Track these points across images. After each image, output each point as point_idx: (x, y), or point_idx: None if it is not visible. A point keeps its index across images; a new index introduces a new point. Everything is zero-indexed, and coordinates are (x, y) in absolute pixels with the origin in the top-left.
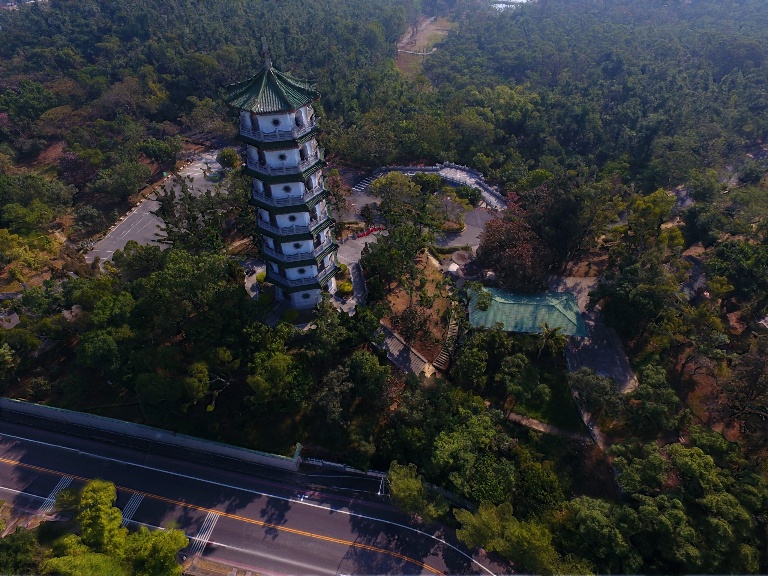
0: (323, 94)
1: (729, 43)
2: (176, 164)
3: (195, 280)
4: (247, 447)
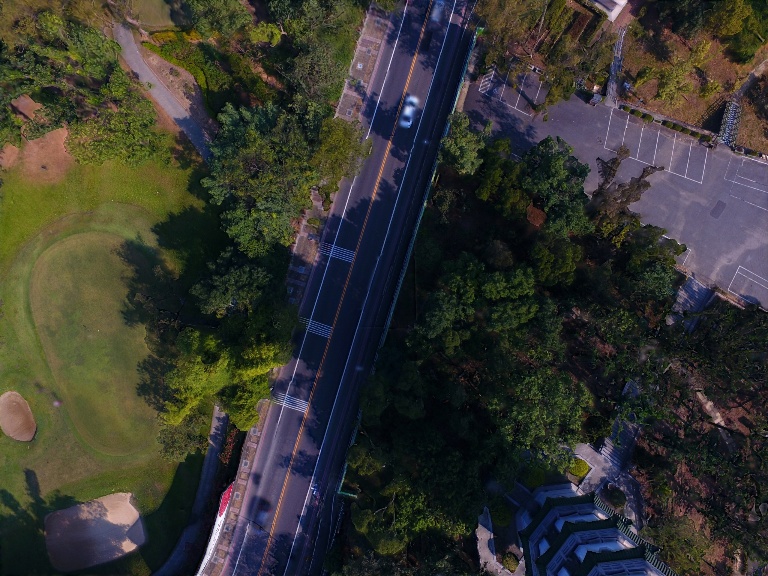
0: None
1: None
2: None
3: (510, 447)
4: (358, 442)
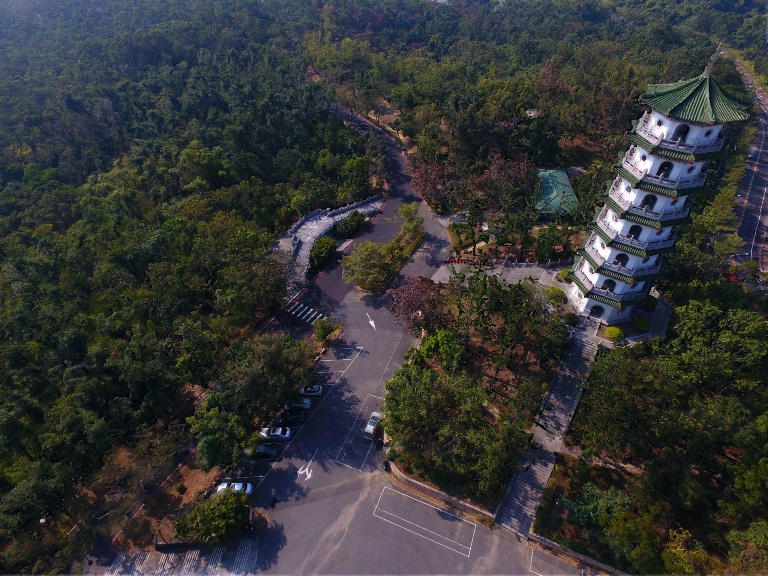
0: (17, 358)
1: (134, 41)
2: None
3: None
4: None
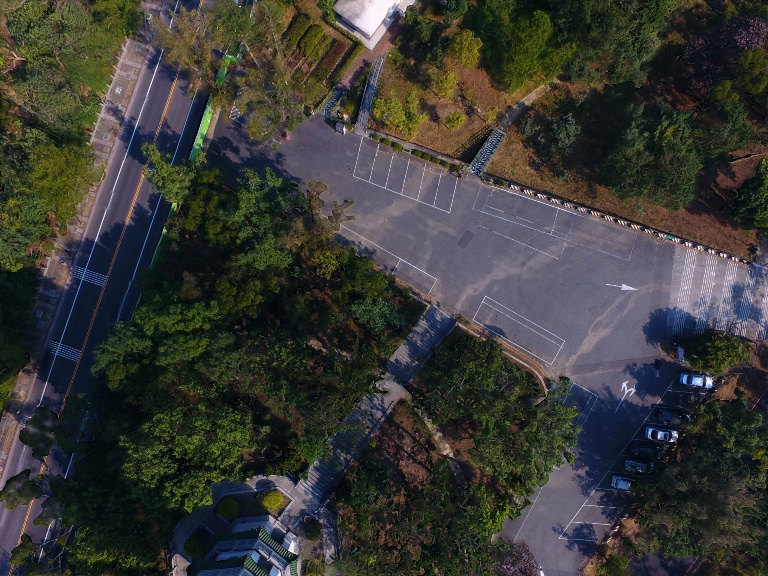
0: None
1: None
2: (742, 230)
3: (133, 485)
4: None
